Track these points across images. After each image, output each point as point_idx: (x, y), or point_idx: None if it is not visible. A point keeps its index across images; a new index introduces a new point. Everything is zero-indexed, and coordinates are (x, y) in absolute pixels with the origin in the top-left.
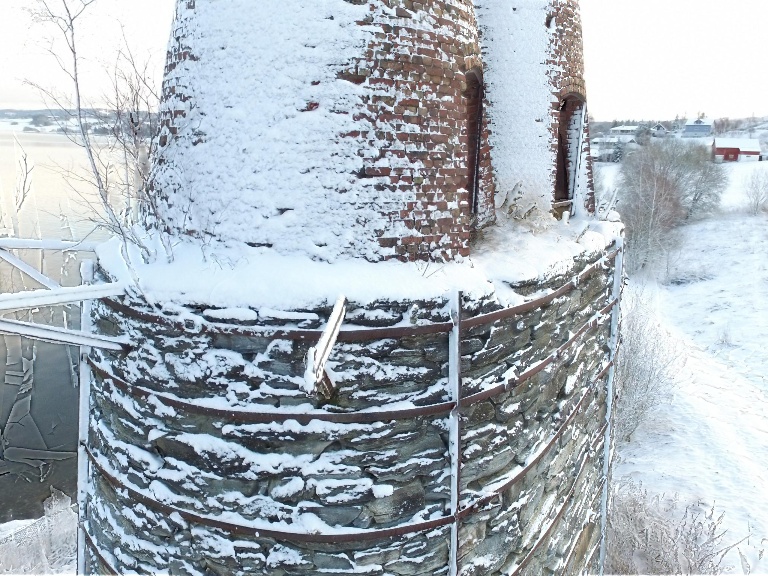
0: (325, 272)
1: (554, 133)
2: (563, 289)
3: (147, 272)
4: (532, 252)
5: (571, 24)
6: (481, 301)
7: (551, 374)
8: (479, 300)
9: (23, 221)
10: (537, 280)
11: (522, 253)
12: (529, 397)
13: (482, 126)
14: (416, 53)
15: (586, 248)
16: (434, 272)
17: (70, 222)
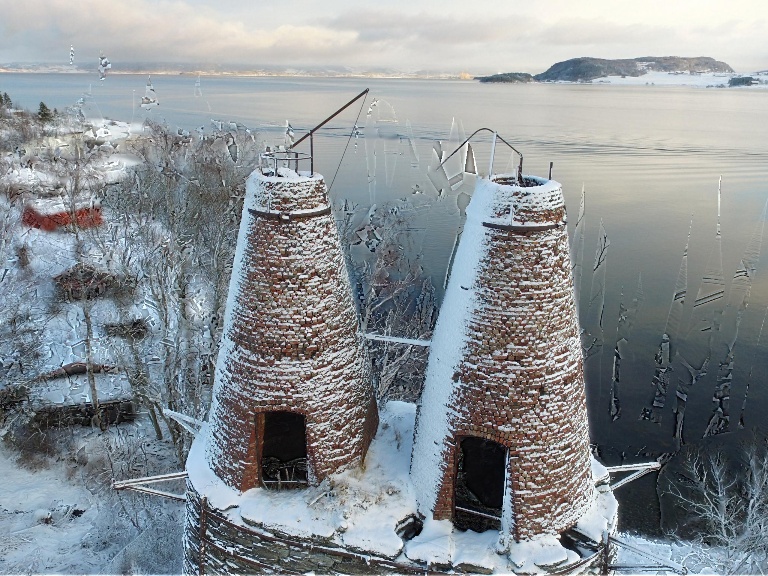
0: (201, 460)
1: (445, 458)
2: (286, 541)
3: (206, 425)
4: (281, 511)
5: (481, 385)
6: (216, 509)
7: (271, 575)
8: (215, 508)
9: (594, 282)
10: (258, 523)
11: (274, 508)
12: (247, 570)
13: (307, 435)
14: (231, 399)
15: (344, 539)
16: (210, 485)
17: (638, 289)
